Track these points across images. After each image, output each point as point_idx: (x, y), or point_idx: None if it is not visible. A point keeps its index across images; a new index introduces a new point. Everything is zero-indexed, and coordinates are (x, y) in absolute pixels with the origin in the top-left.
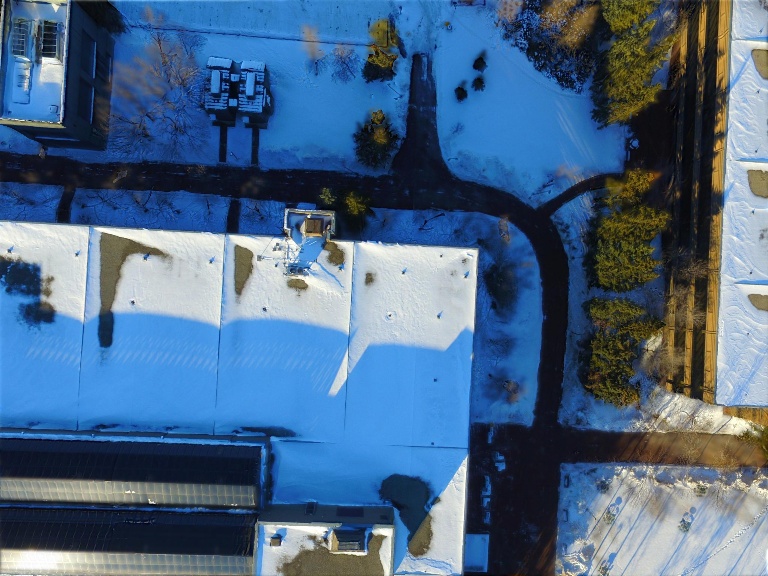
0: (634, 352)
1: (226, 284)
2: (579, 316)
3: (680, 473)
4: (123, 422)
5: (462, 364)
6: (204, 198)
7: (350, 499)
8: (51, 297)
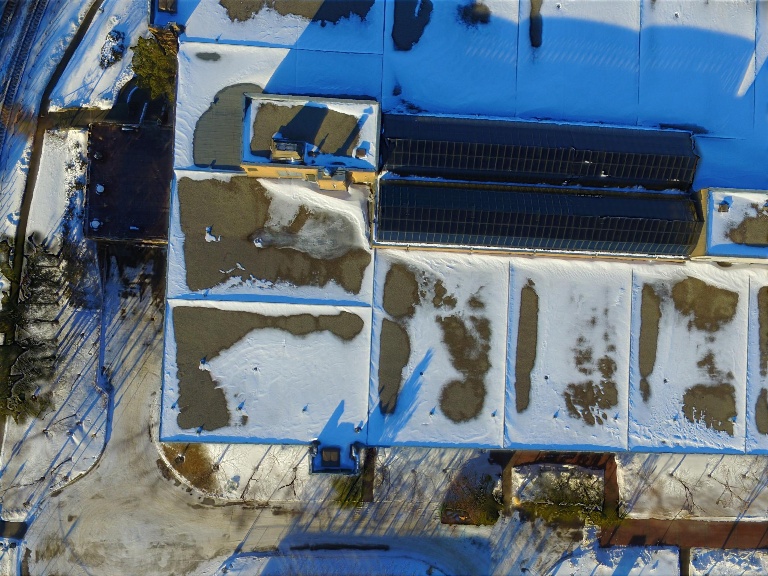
0: None
1: None
2: None
3: None
4: (555, 116)
5: None
6: None
7: None
8: None
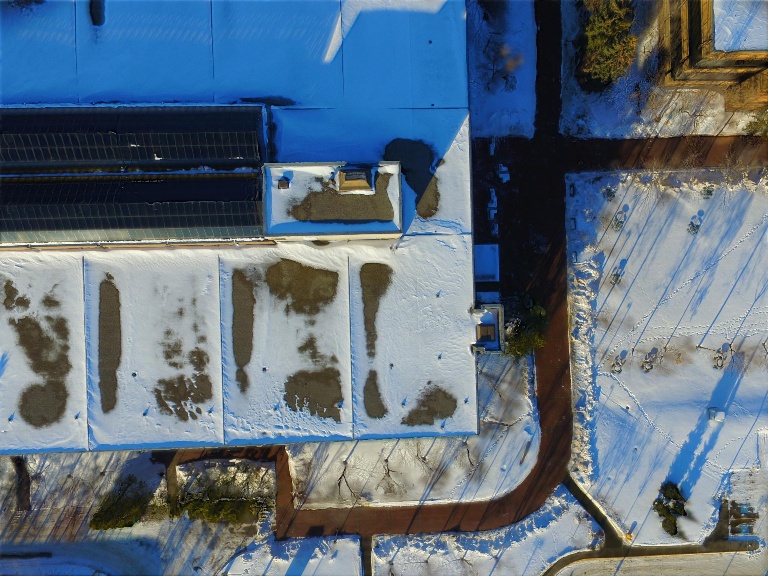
0: (629, 8)
1: None
2: (573, 24)
3: (685, 177)
4: (123, 98)
5: (456, 24)
6: None
7: None
8: None
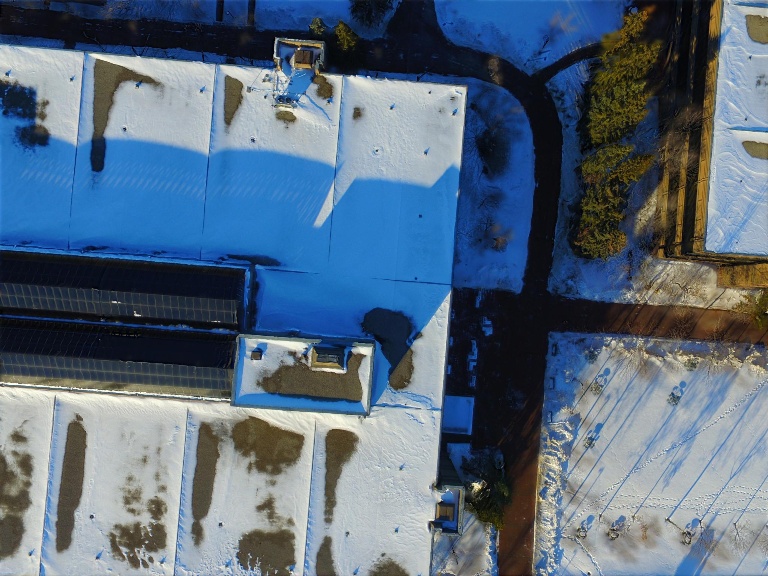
0: (623, 198)
1: (216, 113)
2: (572, 184)
3: (671, 346)
4: (113, 244)
5: (448, 201)
6: (200, 55)
7: (333, 330)
8: (46, 121)
